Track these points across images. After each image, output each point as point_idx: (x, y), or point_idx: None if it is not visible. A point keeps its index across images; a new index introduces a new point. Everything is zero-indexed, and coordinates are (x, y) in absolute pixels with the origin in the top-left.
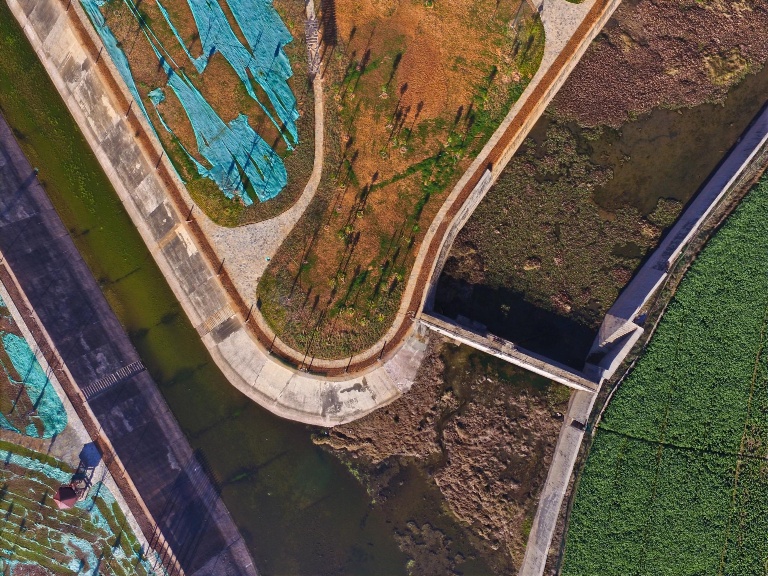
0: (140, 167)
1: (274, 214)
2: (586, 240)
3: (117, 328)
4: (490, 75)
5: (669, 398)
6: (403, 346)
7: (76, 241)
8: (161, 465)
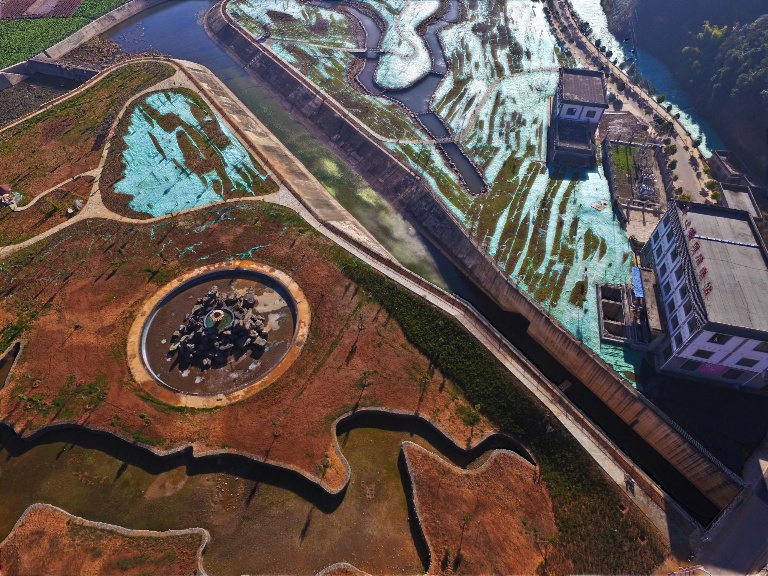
0: (225, 104)
1: (158, 90)
2: (7, 102)
3: (254, 75)
4: (18, 133)
5: (0, 61)
6: (113, 65)
7: (271, 95)
8: (236, 45)
